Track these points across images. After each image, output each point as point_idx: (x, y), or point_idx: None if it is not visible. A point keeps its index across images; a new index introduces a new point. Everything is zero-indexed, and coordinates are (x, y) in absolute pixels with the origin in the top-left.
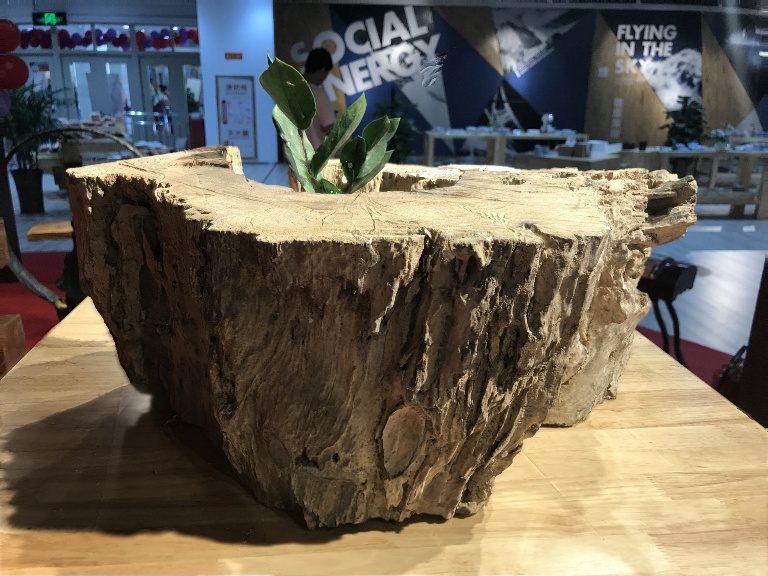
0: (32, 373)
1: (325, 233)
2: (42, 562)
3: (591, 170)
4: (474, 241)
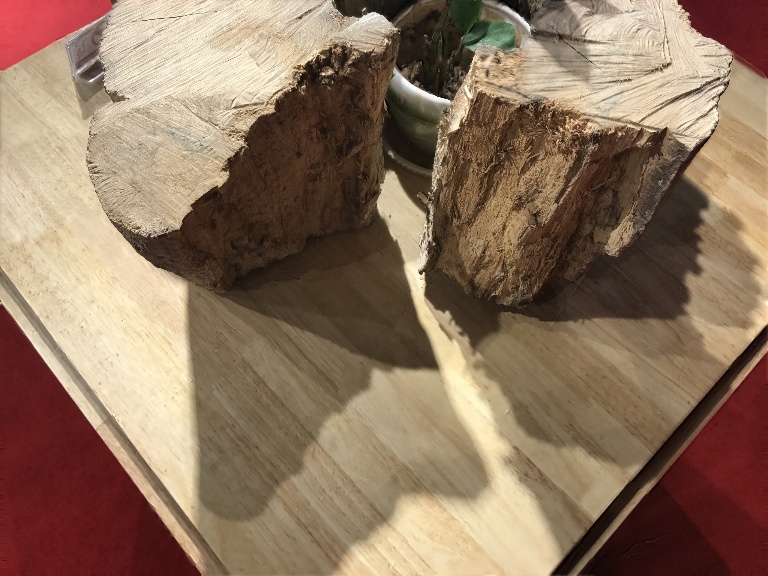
0: (623, 435)
1: None
2: (699, 156)
3: None
4: None
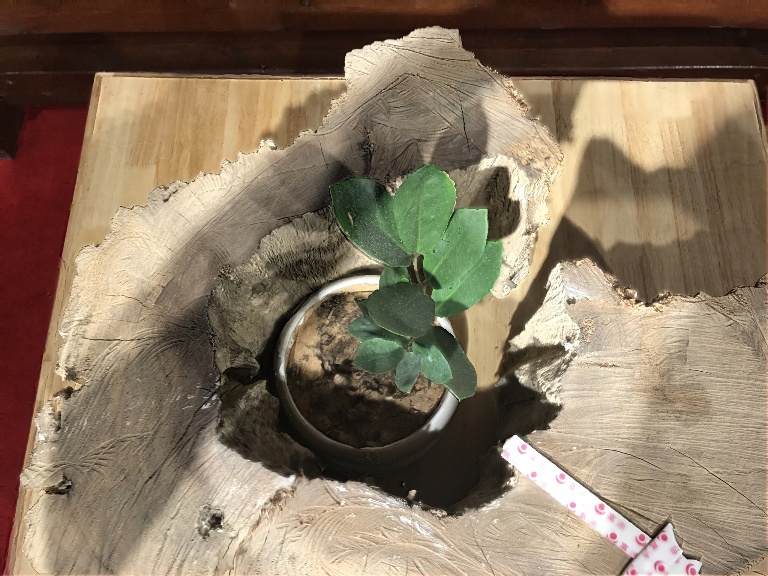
0: None
1: (87, 297)
2: None
3: None
4: (39, 421)
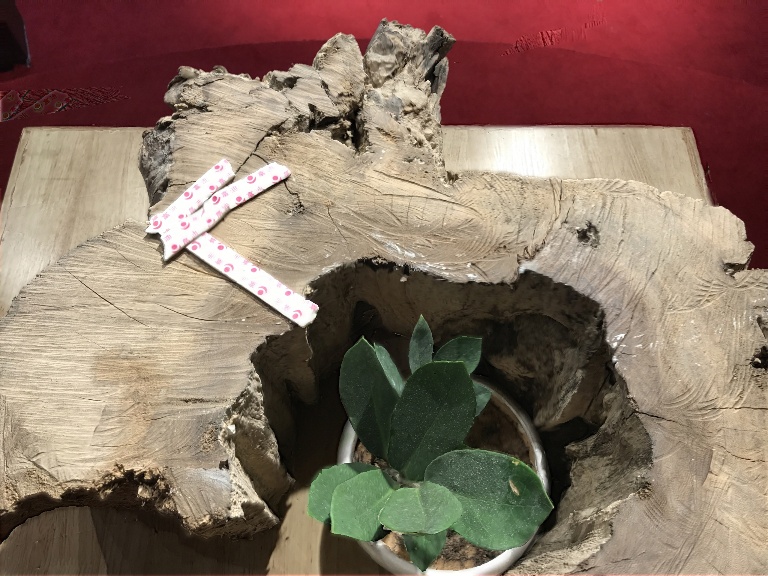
0: None
1: None
2: None
3: (275, 74)
4: None
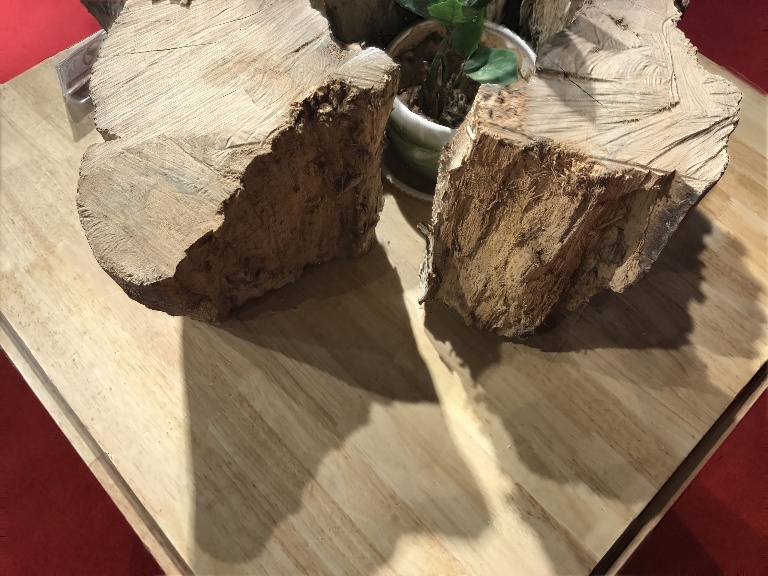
0: (626, 471)
1: None
2: None
3: None
4: None
